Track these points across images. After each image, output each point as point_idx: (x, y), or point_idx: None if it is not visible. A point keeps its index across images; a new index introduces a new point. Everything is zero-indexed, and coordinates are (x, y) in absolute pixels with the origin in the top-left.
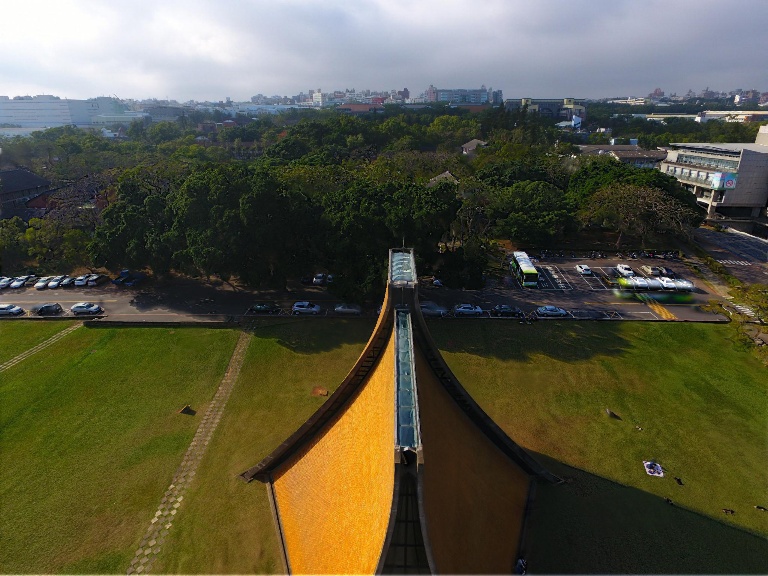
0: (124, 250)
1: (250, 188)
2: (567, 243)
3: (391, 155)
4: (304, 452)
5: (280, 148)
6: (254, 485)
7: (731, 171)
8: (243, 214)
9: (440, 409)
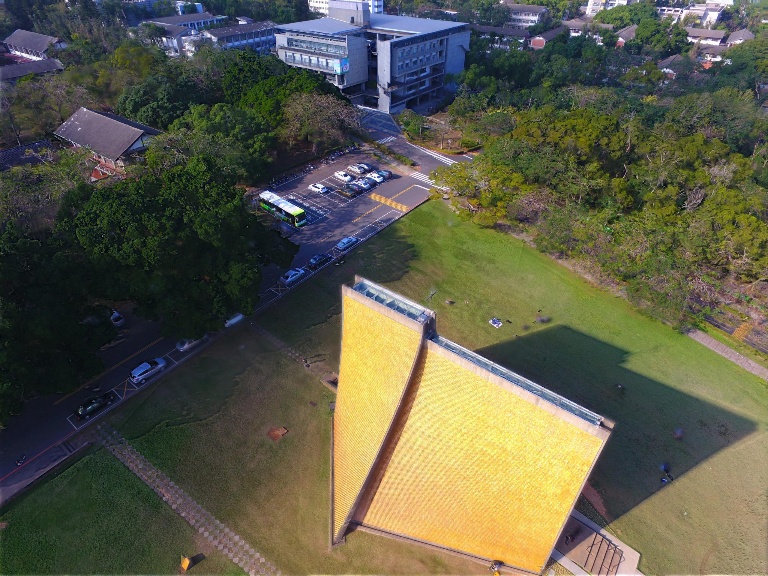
0: None
1: None
2: None
3: None
4: (376, 482)
5: None
6: (352, 539)
7: (344, 56)
8: None
9: None
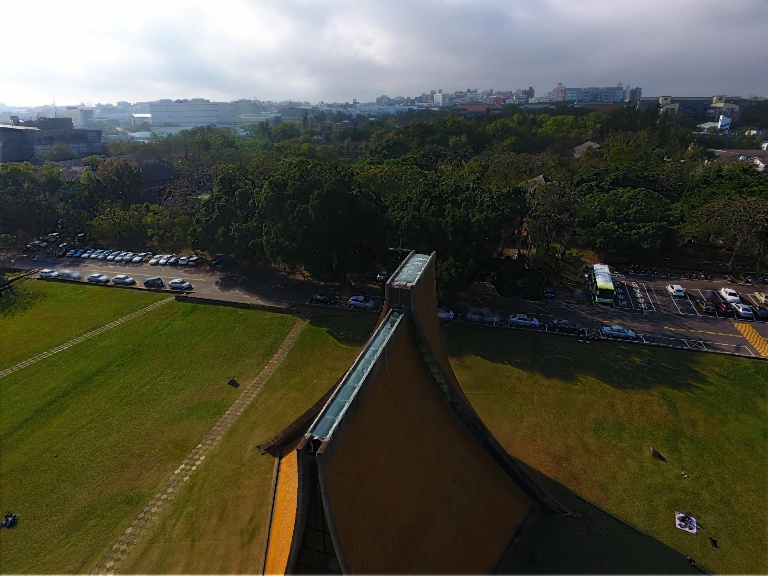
0: (214, 236)
1: (321, 185)
2: (666, 259)
3: (490, 157)
4: None
5: (381, 148)
6: (265, 458)
7: None
8: (311, 209)
9: (426, 413)
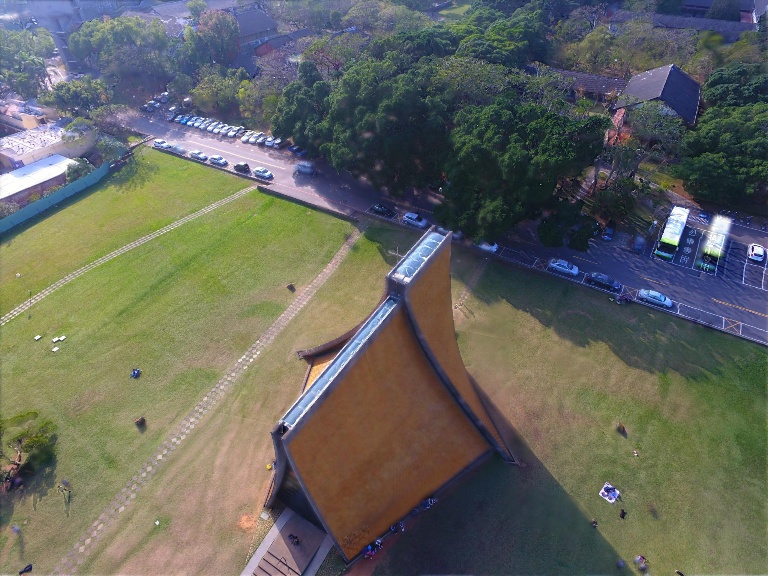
0: (293, 129)
1: (391, 94)
2: None
3: (625, 18)
4: (331, 358)
5: None
6: (302, 363)
7: None
8: (377, 122)
9: (406, 379)
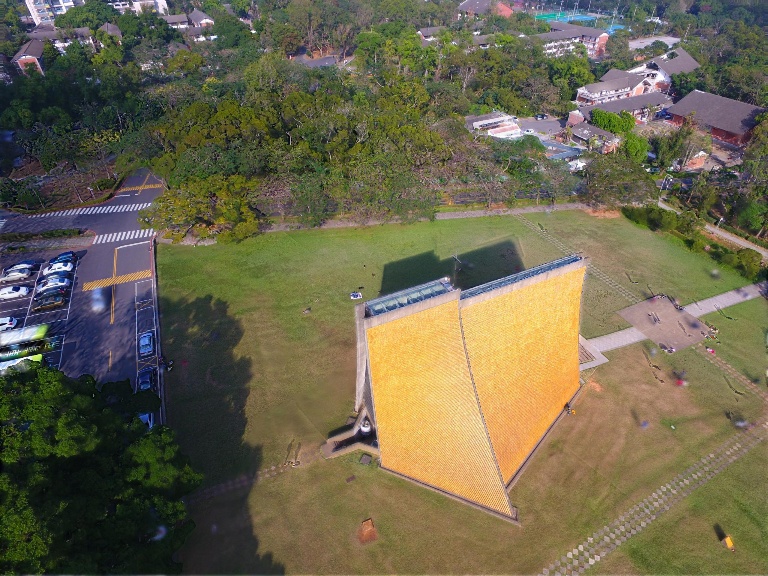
0: None
1: None
2: None
3: None
4: None
5: None
6: (516, 501)
7: None
8: None
9: None
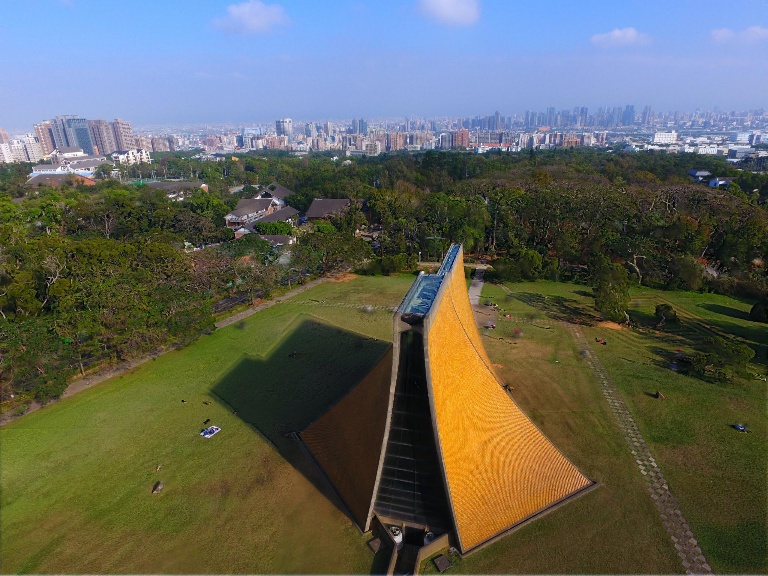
0: None
1: None
2: None
3: None
4: None
5: None
6: None
7: None
8: None
9: None
